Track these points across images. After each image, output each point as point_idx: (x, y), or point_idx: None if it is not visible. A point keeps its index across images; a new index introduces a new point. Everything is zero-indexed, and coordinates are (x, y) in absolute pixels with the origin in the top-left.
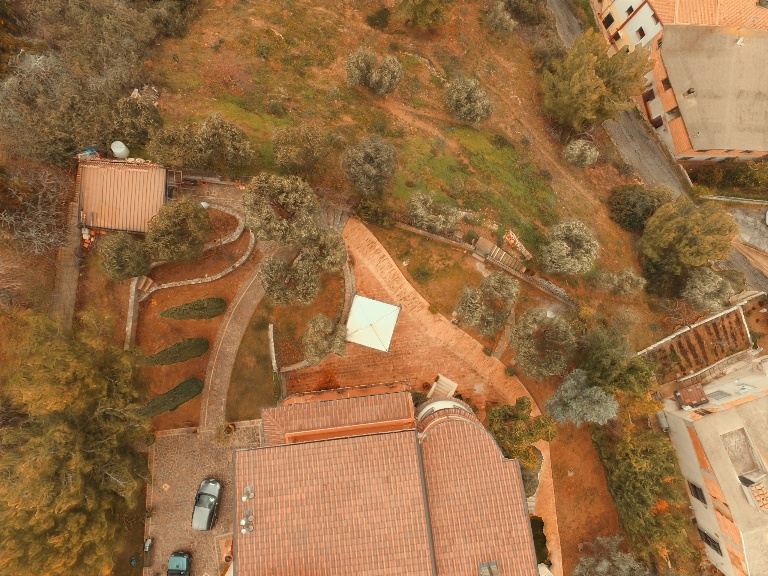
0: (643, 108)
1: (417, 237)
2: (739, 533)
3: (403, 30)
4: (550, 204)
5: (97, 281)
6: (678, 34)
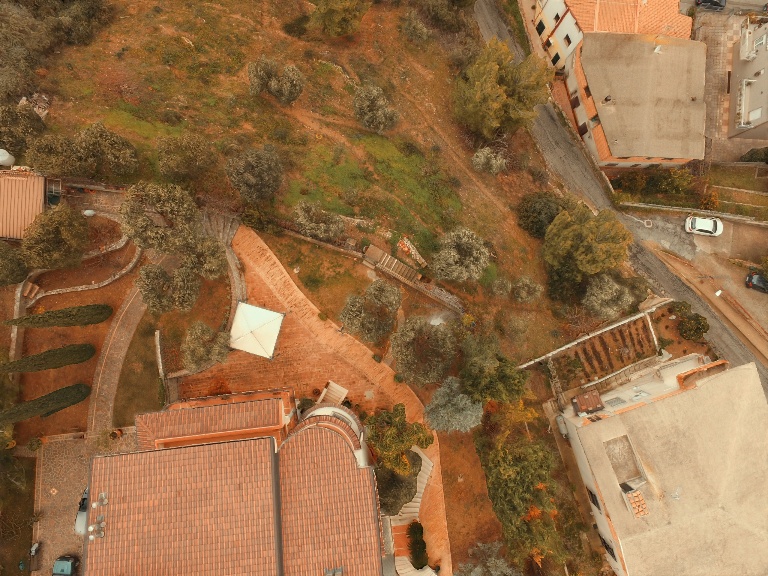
0: (571, 115)
1: (308, 244)
2: (618, 539)
3: (320, 37)
4: (449, 212)
5: None
6: (597, 42)
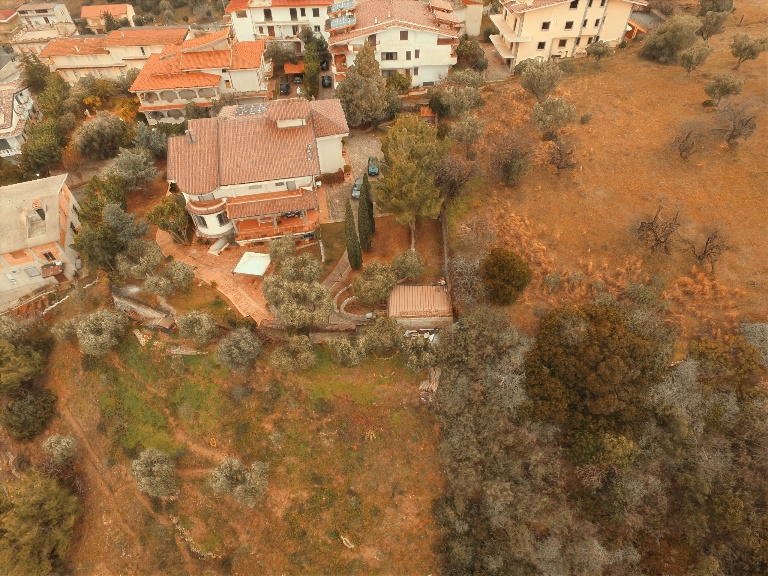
0: None
1: None
2: None
3: None
4: None
5: (433, 263)
6: None
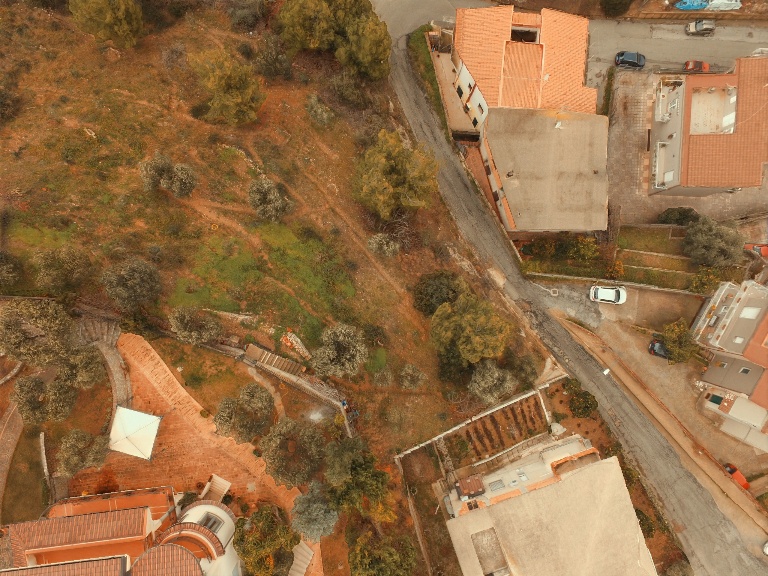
0: (486, 180)
1: (190, 344)
2: None
3: None
4: None
5: None
6: (501, 117)
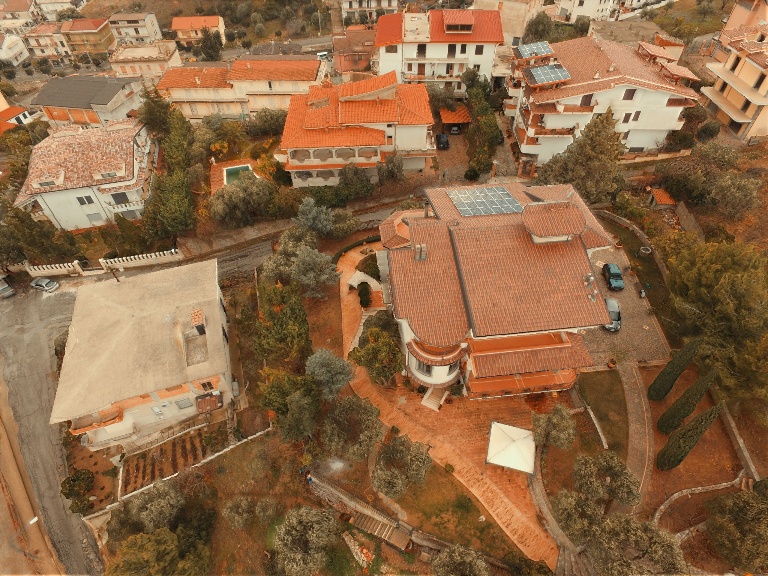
0: None
1: None
2: None
3: None
4: None
5: None
6: None
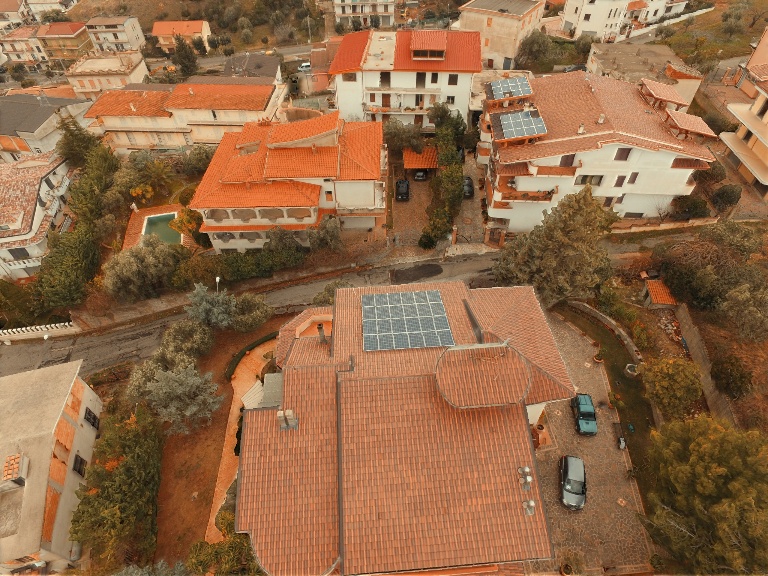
0: None
1: None
2: None
3: None
4: None
5: None
6: None
